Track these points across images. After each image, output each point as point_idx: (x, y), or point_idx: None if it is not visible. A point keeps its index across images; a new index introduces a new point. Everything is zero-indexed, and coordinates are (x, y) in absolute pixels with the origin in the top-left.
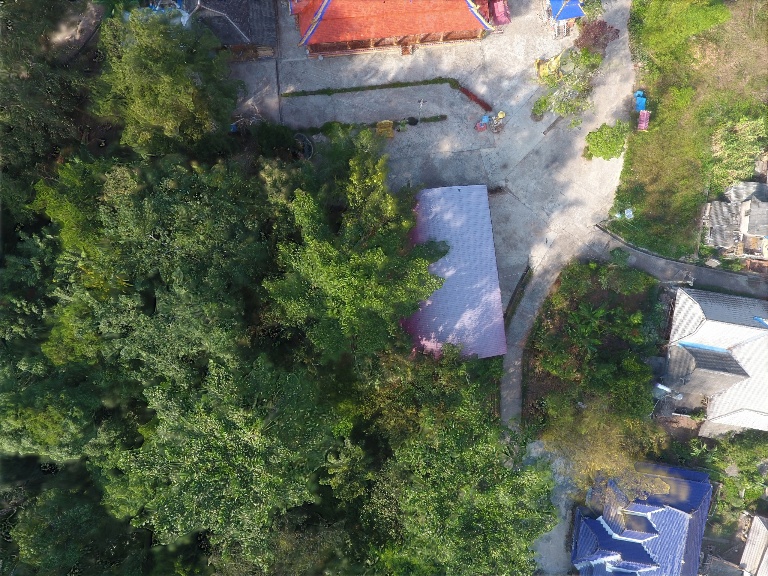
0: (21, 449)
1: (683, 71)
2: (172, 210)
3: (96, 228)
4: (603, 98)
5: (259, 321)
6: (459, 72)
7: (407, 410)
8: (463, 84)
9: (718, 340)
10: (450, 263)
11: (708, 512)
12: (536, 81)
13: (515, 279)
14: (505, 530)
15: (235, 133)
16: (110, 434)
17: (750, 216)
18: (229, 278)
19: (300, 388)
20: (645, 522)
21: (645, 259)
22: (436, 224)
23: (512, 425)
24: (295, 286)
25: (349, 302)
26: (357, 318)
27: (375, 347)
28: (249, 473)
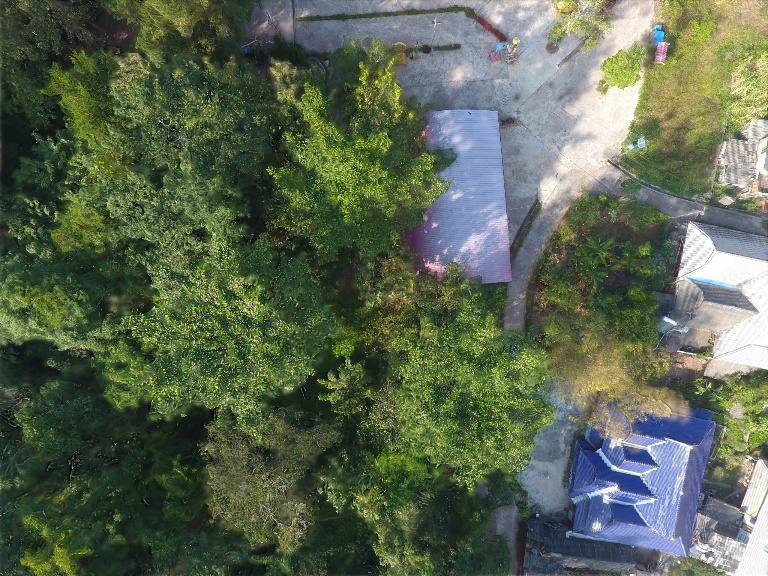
0: (28, 330)
1: (704, 6)
2: (182, 96)
3: (108, 116)
4: (621, 32)
5: (265, 227)
6: (475, 1)
7: (408, 329)
8: (479, 13)
9: (728, 275)
10: (458, 186)
11: (710, 455)
12: (552, 1)
13: (523, 212)
14: (500, 418)
15: (249, 55)
16: (115, 328)
17: (767, 152)
18: (236, 173)
19: (301, 272)
20: (645, 454)
21: (657, 197)
22: (445, 146)
23: (512, 334)
24: (301, 179)
25: (353, 188)
26: (361, 208)
27: (378, 250)
28: (247, 344)
